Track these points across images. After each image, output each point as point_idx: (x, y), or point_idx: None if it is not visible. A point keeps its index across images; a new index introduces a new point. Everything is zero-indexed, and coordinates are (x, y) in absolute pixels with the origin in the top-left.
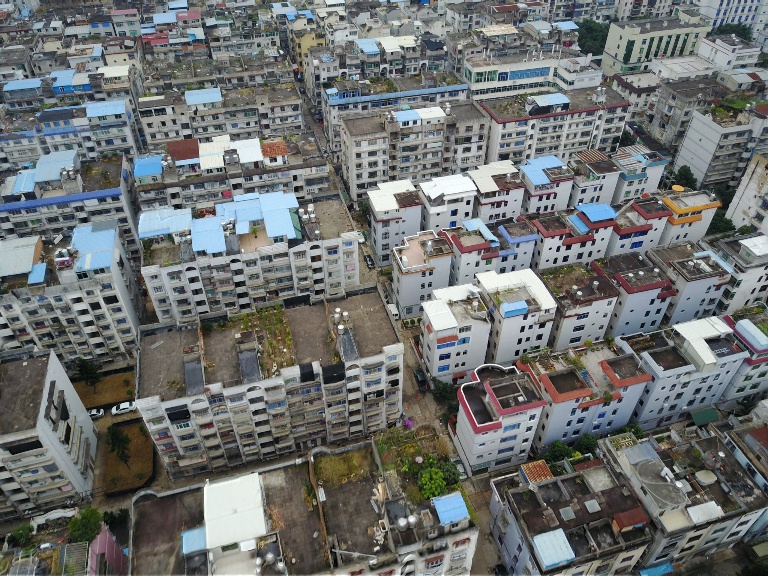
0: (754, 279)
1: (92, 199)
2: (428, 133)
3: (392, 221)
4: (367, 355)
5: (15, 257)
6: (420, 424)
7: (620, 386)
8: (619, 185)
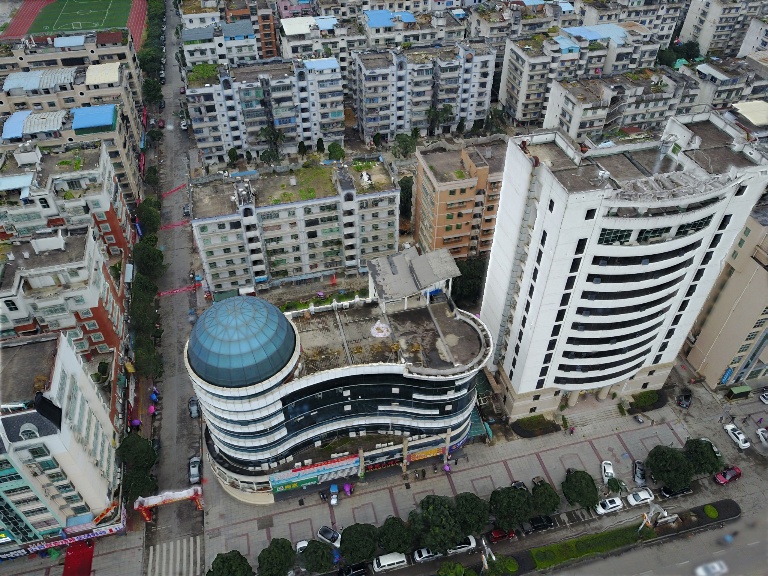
0: None
1: None
2: None
3: None
4: None
5: None
6: None
7: None
8: None
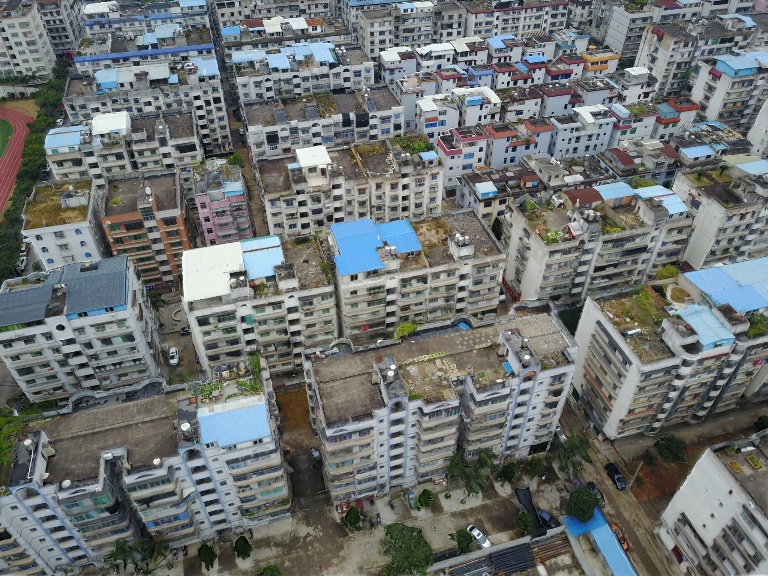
0: (635, 96)
1: (194, 51)
2: (421, 19)
3: (396, 70)
4: (382, 110)
5: (158, 70)
6: (413, 134)
7: (534, 131)
8: (556, 54)
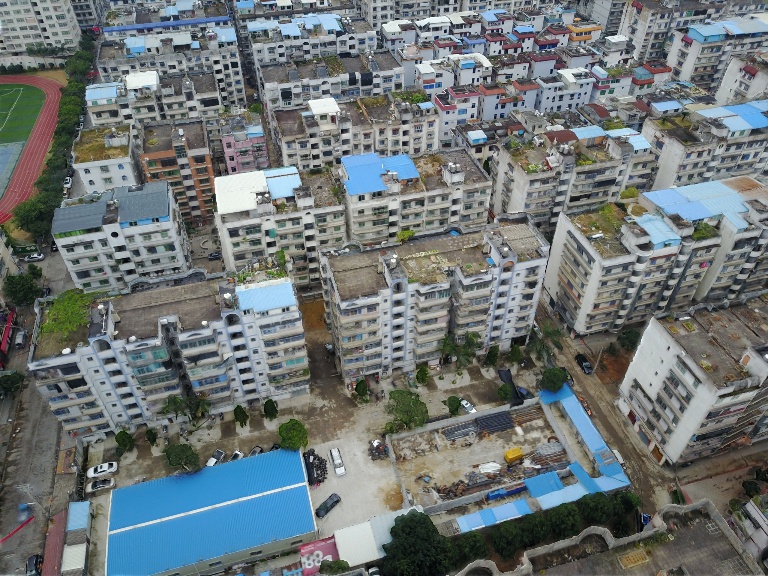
0: (615, 62)
1: (212, 22)
2: None
3: (397, 41)
4: (384, 70)
5: (181, 37)
6: (412, 90)
7: (521, 90)
8: None
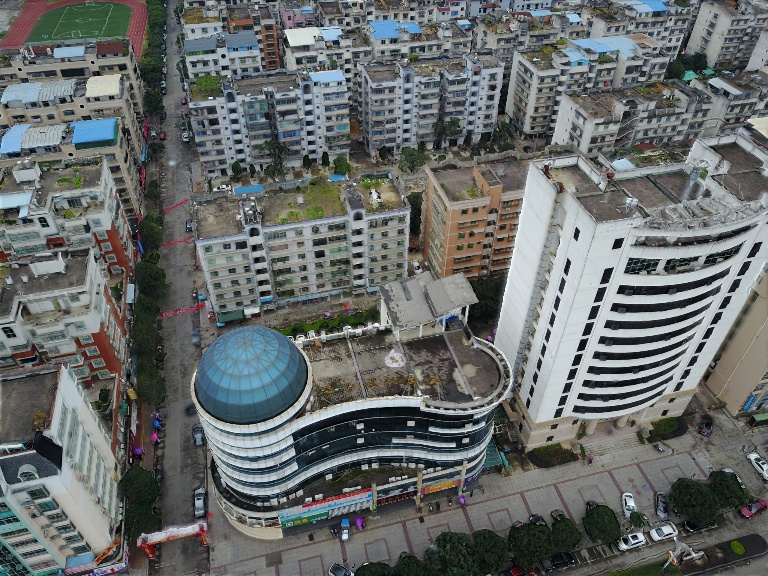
0: None
1: None
2: None
3: None
4: None
5: None
6: None
7: None
8: None
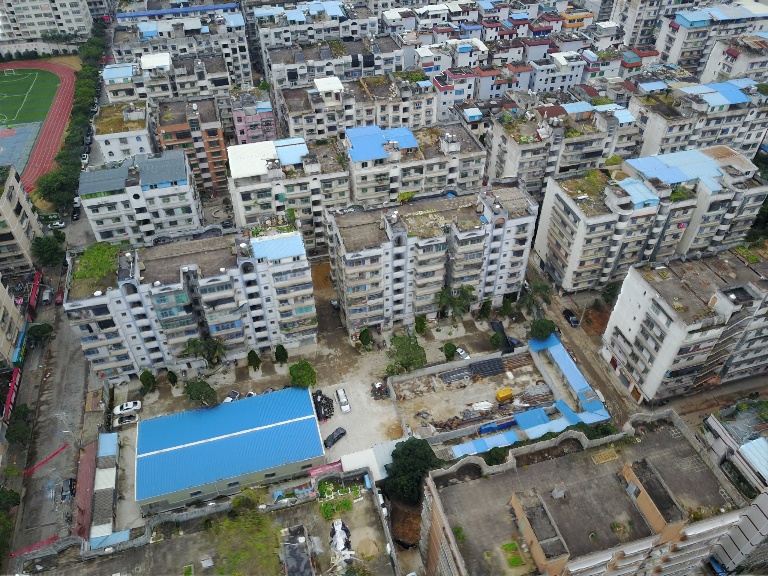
0: (606, 47)
1: (220, 9)
2: None
3: (397, 28)
4: None
5: (191, 22)
6: (412, 70)
7: (515, 71)
8: None
